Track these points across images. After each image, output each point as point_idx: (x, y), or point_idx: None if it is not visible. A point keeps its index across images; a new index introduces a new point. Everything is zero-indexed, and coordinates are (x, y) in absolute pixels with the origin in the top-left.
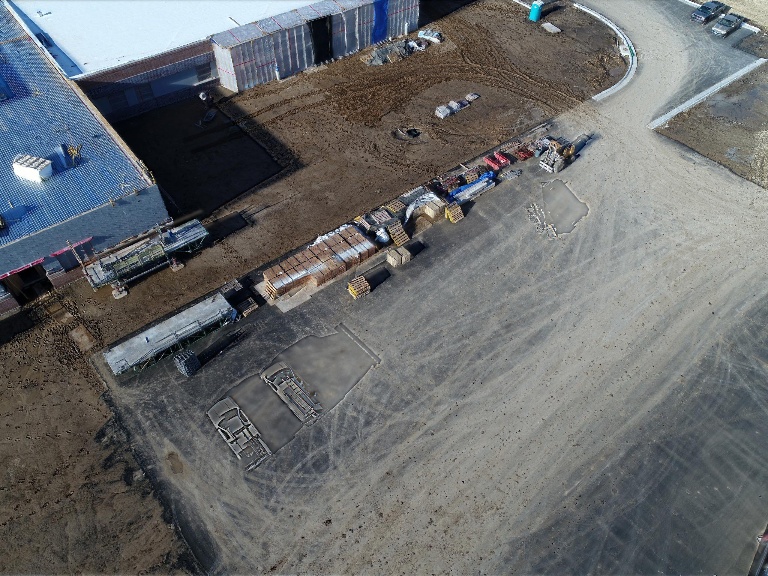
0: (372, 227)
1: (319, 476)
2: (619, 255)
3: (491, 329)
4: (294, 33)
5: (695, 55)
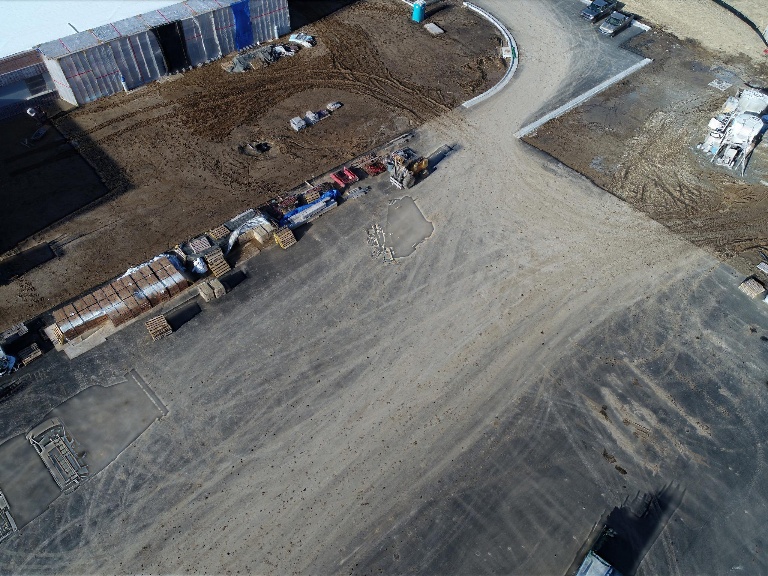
0: (189, 257)
1: (65, 555)
2: (455, 280)
3: (299, 370)
4: (137, 40)
5: (579, 56)
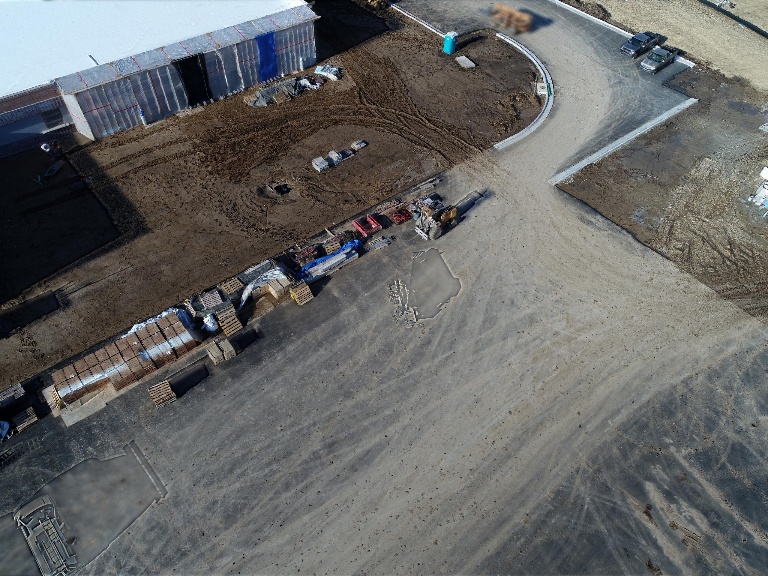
0: (199, 313)
1: None
2: (484, 348)
3: (310, 449)
4: (157, 74)
5: (619, 94)
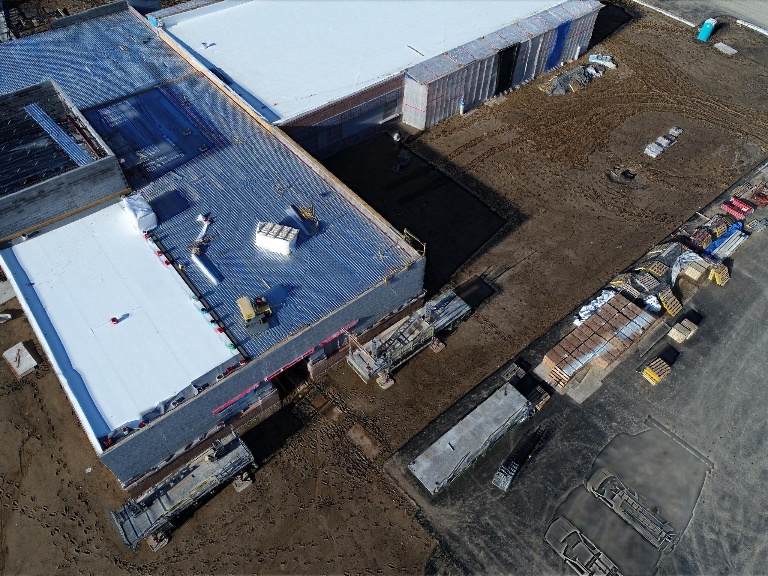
0: (641, 294)
1: None
2: None
3: None
4: (485, 64)
5: None
